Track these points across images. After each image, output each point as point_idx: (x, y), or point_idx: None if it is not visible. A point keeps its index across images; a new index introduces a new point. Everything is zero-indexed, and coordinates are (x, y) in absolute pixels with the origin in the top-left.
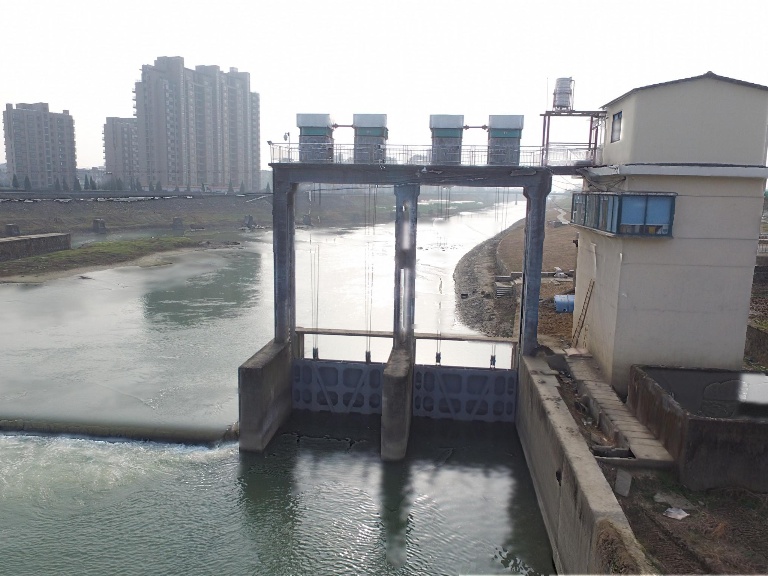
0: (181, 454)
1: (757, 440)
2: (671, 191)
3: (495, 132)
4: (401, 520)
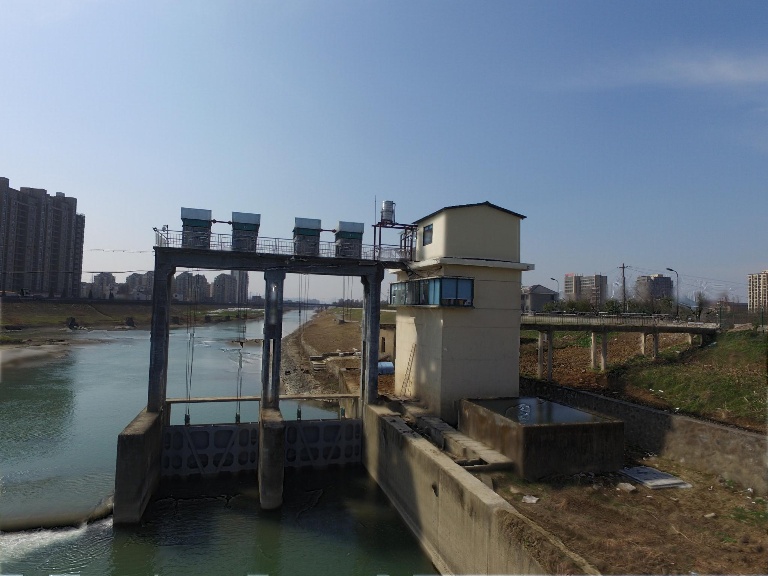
0: (41, 539)
1: (563, 437)
2: None
3: (344, 234)
4: (263, 570)
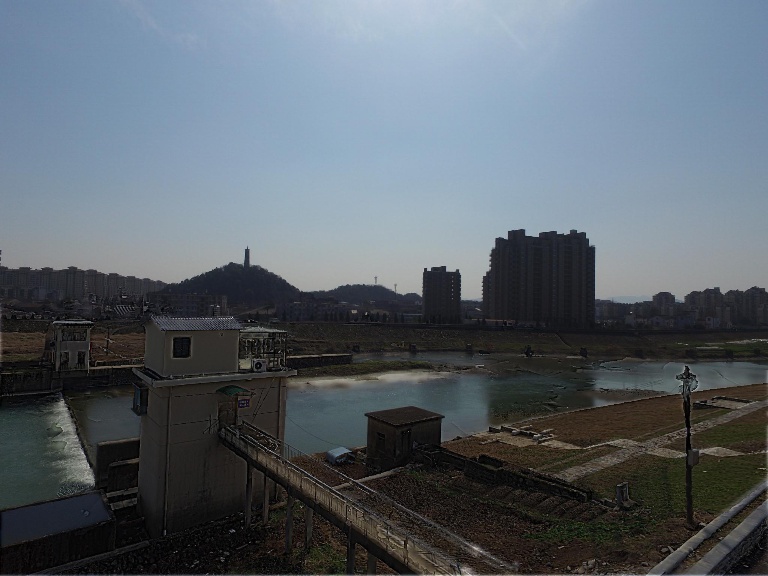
0: None
1: None
2: None
3: None
4: None
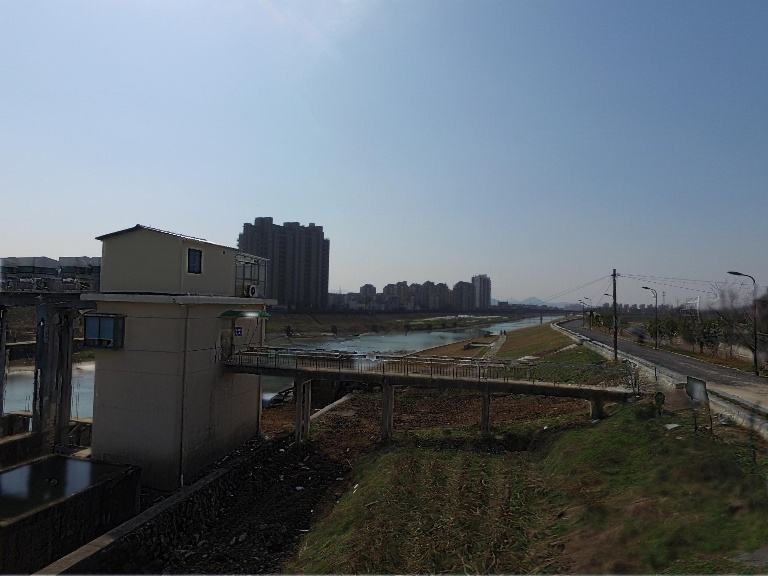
0: None
1: None
2: (122, 313)
3: (95, 269)
4: None
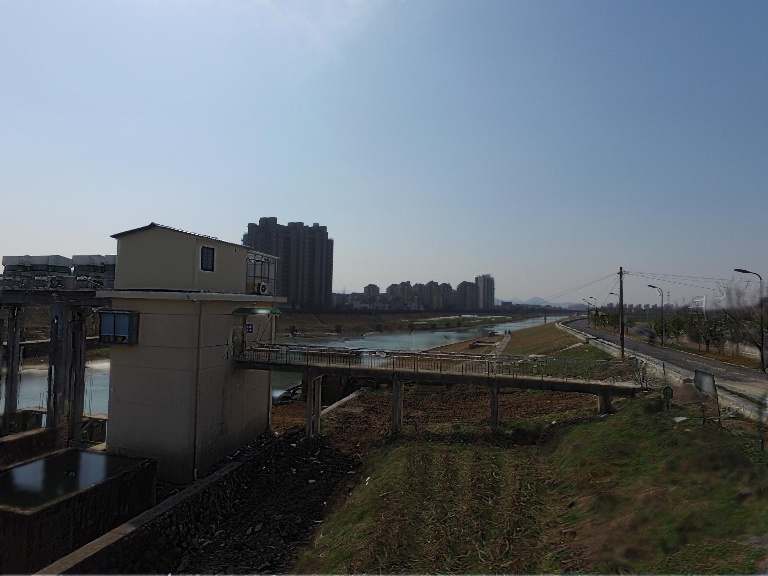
0: None
1: None
2: (136, 310)
3: (108, 267)
4: None
